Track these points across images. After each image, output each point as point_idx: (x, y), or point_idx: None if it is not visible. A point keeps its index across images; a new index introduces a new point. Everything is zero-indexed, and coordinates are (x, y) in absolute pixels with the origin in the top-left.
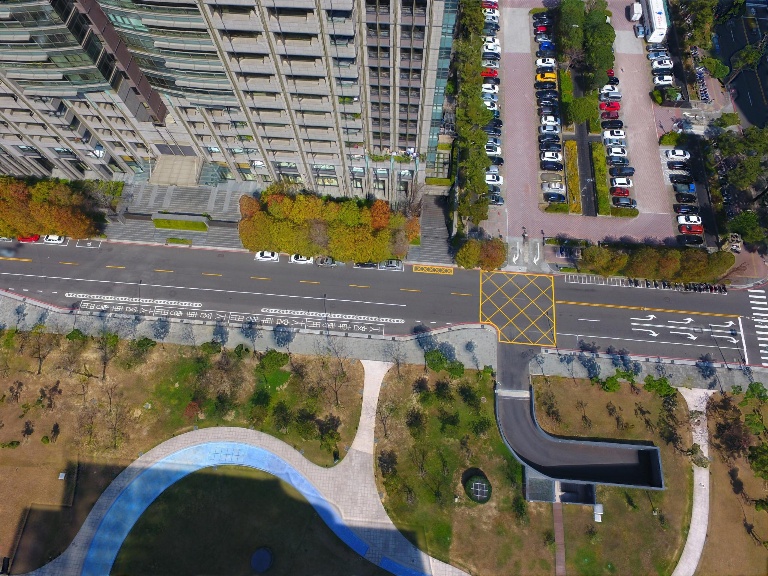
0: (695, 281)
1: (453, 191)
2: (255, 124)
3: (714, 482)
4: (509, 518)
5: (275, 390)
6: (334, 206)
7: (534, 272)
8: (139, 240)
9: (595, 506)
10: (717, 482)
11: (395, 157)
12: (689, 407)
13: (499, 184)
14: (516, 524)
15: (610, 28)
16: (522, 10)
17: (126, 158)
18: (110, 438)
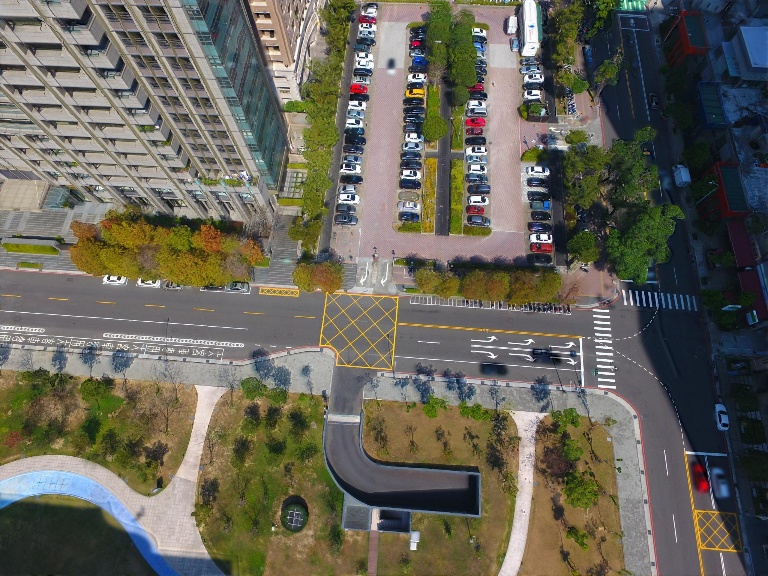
0: (540, 301)
1: (302, 212)
2: (72, 151)
3: (535, 508)
4: (324, 547)
5: (107, 417)
6: (163, 231)
7: (380, 293)
8: None
9: (412, 534)
10: (538, 508)
11: (226, 181)
12: (519, 431)
13: (355, 203)
14: (330, 553)
15: (469, 44)
16: (400, 24)
17: None
18: None
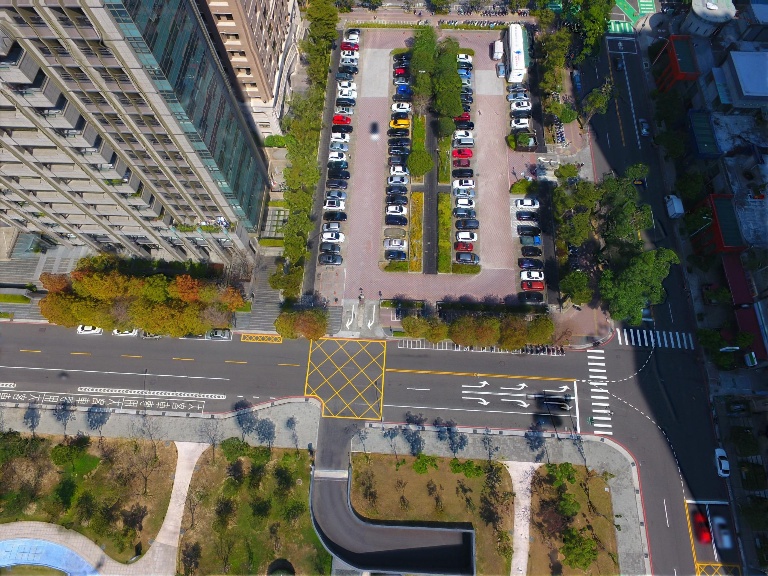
0: None
1: None
2: (38, 203)
3: (532, 566)
4: None
5: (82, 478)
6: (138, 282)
7: (367, 338)
8: None
9: None
10: (535, 566)
11: (203, 227)
12: (513, 483)
13: (339, 242)
14: None
15: (454, 74)
16: (383, 51)
17: None
18: None
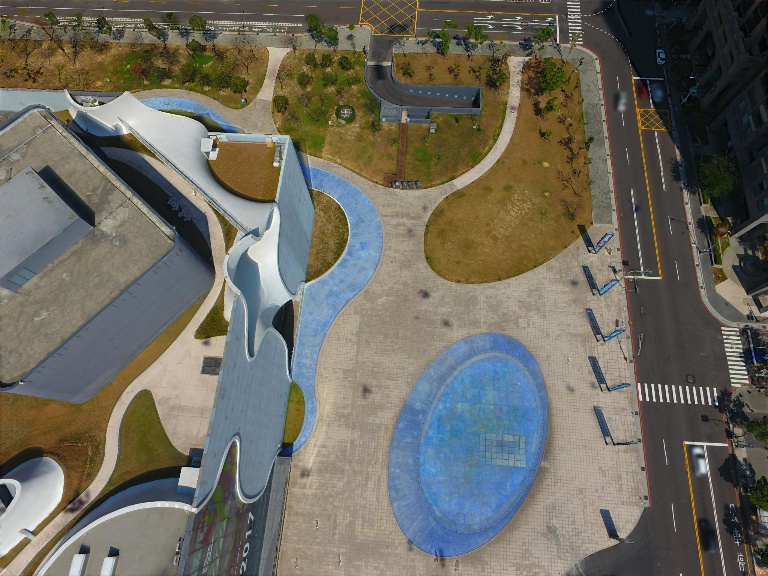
0: None
1: None
2: None
3: (521, 110)
4: (367, 132)
5: (202, 67)
6: None
7: None
8: None
9: (431, 124)
10: (523, 110)
11: None
12: (510, 68)
13: None
14: (372, 135)
15: None
16: None
17: None
18: None
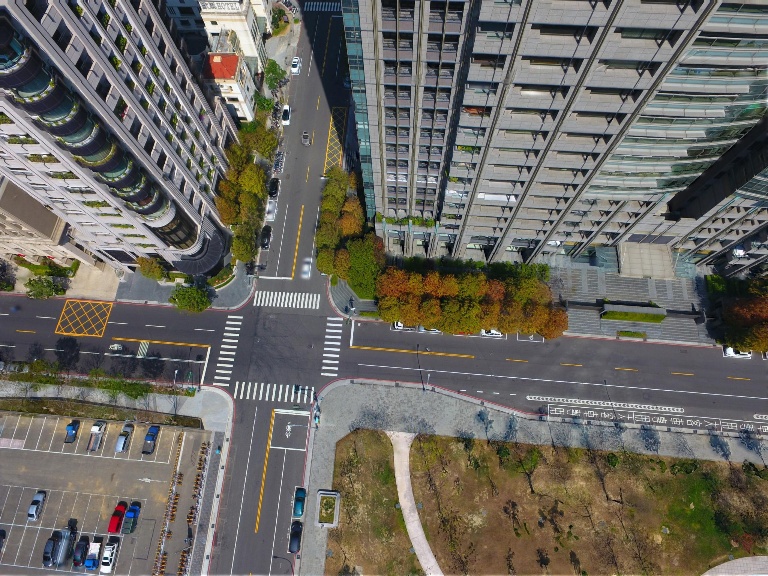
0: None
1: None
2: None
3: None
4: None
5: None
6: None
7: None
8: (585, 333)
9: None
10: None
11: None
12: None
13: None
14: None
15: None
16: None
17: (566, 242)
18: (639, 569)
